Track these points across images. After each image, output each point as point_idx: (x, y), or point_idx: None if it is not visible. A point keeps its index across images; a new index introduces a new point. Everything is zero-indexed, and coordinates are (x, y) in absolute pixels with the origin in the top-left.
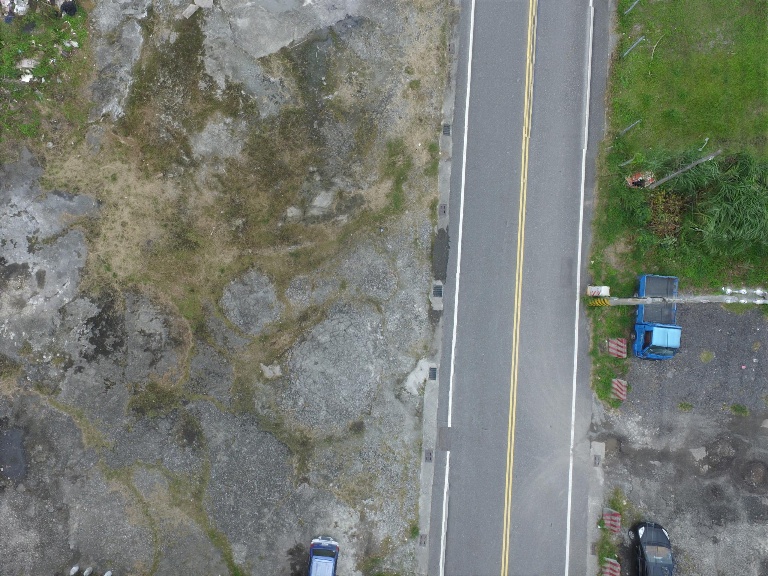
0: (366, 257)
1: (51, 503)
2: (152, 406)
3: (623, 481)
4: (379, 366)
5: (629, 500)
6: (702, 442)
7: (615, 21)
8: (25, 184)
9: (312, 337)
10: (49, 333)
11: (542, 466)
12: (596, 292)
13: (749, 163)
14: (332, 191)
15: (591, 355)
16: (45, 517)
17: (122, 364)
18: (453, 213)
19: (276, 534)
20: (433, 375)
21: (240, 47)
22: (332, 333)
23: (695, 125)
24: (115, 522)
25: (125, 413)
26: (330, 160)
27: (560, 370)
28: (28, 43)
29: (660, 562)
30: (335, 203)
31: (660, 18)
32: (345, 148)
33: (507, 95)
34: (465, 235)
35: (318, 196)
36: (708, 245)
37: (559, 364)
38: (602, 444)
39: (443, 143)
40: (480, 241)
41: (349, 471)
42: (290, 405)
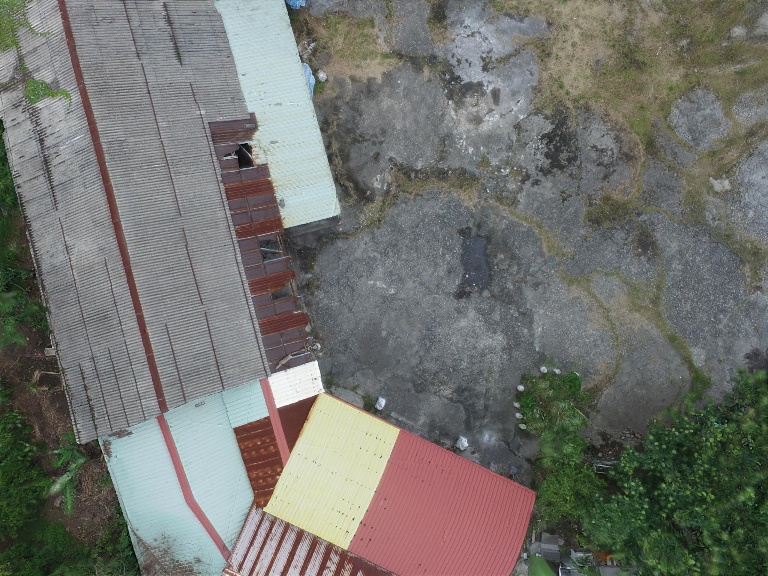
0: None
1: (515, 308)
2: (606, 218)
3: None
4: None
5: None
6: None
7: None
8: (477, 6)
9: (759, 152)
10: (506, 148)
11: None
12: None
13: None
14: None
15: None
16: (511, 321)
17: (577, 177)
18: None
19: (732, 339)
20: None
21: None
22: None
23: None
24: (578, 326)
25: (582, 224)
26: None
27: None
28: None
29: None
30: None
31: None
32: None
33: None
34: None
35: (760, 17)
36: None
37: None
38: None
39: None
40: None
41: None
42: (740, 217)
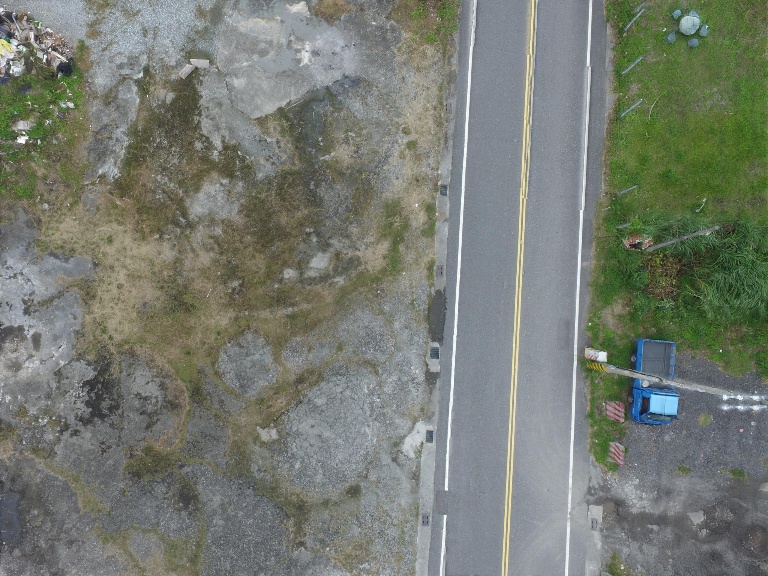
0: (363, 319)
1: (46, 568)
2: (148, 470)
3: (621, 545)
4: (376, 429)
5: (627, 564)
6: (700, 506)
7: (612, 81)
8: (21, 246)
9: (309, 400)
10: (45, 396)
11: (539, 530)
12: (593, 356)
13: (746, 231)
14: (329, 252)
15: (588, 418)
16: None
17: (118, 427)
18: (450, 274)
19: None
20: (430, 438)
21: (236, 107)
22: (329, 396)
23: (693, 185)
24: None
25: (121, 477)
26: (327, 221)
27: (557, 433)
28: (24, 104)
29: None
30: (332, 264)
31: (657, 78)
32: (342, 209)
33: (504, 156)
34: (462, 297)
35: (315, 257)
36: (706, 310)
37: (556, 427)
38: (599, 507)
39: (440, 204)
40: (477, 303)
41: (346, 535)
42: (286, 468)
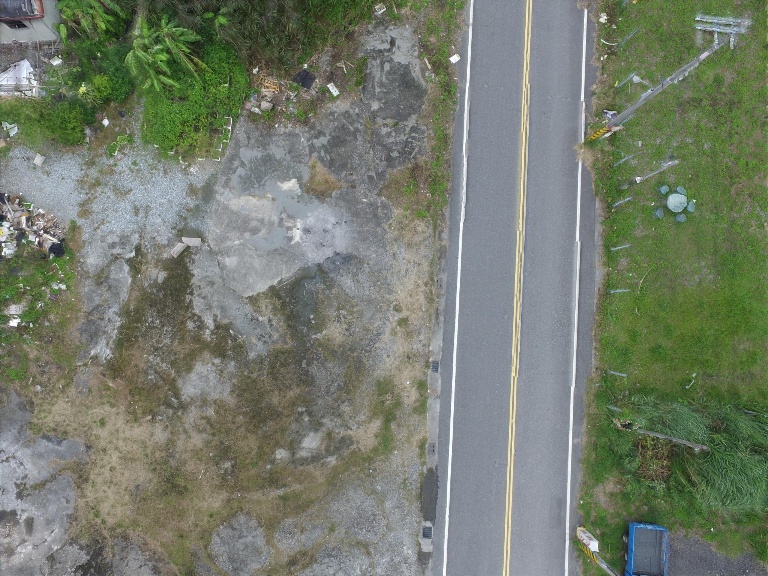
0: (355, 499)
1: None
2: None
3: None
4: None
5: None
6: None
7: (602, 255)
8: (13, 429)
9: None
10: None
11: None
12: (585, 541)
13: (735, 427)
14: (321, 431)
15: None
16: None
17: None
18: (442, 452)
19: None
20: None
21: (228, 286)
22: None
23: (682, 360)
24: None
25: None
26: (319, 400)
27: None
28: (16, 288)
29: None
30: (324, 444)
31: (646, 252)
32: (334, 387)
33: (495, 332)
34: (454, 475)
35: (307, 437)
36: None
37: None
38: None
39: (431, 381)
40: (469, 482)
41: None
42: None
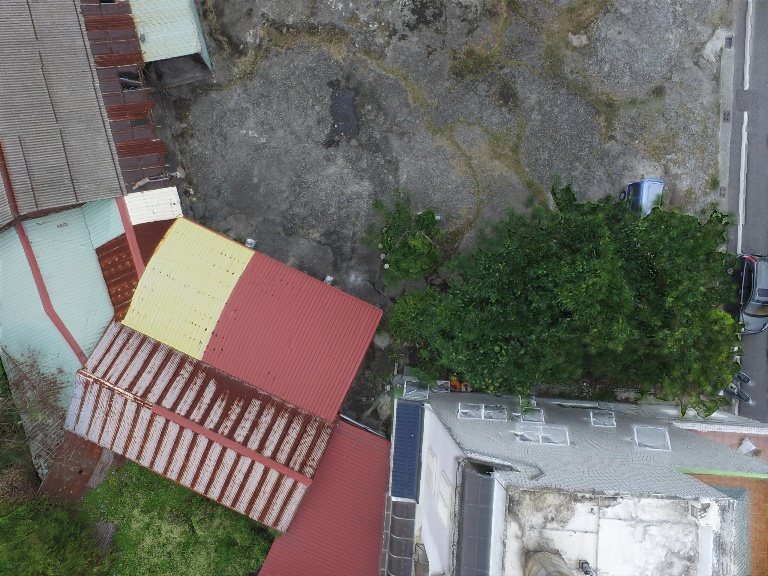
0: None
1: (382, 156)
2: (470, 71)
3: None
4: (679, 35)
5: None
6: None
7: None
8: None
9: (616, 9)
10: (374, 4)
11: None
12: None
13: None
14: None
15: None
16: (377, 168)
17: (442, 32)
18: None
19: (588, 185)
20: (729, 44)
21: None
22: (634, 5)
23: None
24: (441, 173)
25: (446, 77)
26: None
27: None
28: None
29: None
30: None
31: None
32: None
33: None
34: None
35: None
36: None
37: None
38: None
39: None
40: None
41: (653, 130)
42: (597, 71)
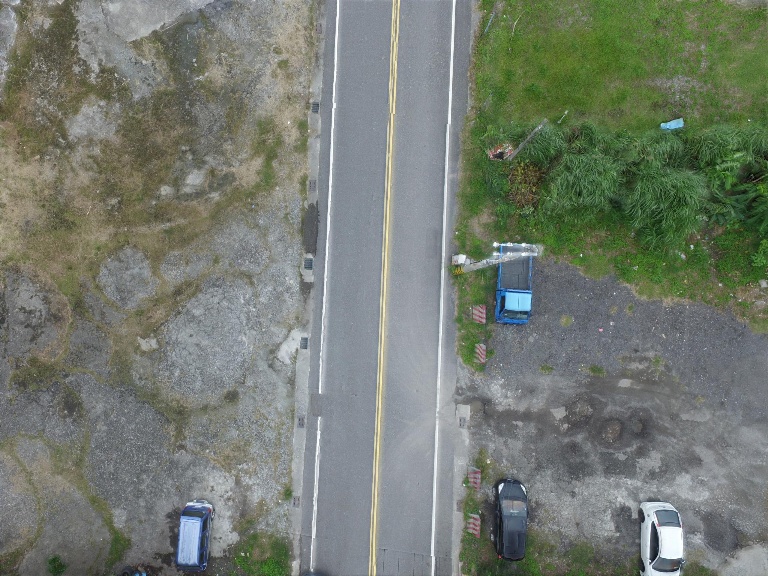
0: (238, 232)
1: None
2: (33, 380)
3: (487, 441)
4: (252, 337)
5: (493, 459)
6: (562, 402)
7: None
8: None
9: (187, 310)
10: None
11: (409, 429)
12: (456, 261)
13: (591, 132)
14: (204, 169)
15: (455, 322)
16: None
17: (3, 340)
18: (322, 188)
19: (155, 499)
20: (304, 344)
21: (112, 31)
22: (206, 306)
23: (555, 98)
24: None
25: (7, 387)
26: (202, 139)
27: (426, 337)
28: None
29: (514, 515)
30: (207, 181)
31: None
32: (216, 127)
33: (372, 73)
34: (334, 209)
35: (191, 174)
36: (561, 213)
37: (425, 331)
38: (467, 406)
39: (312, 121)
40: (348, 215)
41: (224, 438)
42: (167, 376)
